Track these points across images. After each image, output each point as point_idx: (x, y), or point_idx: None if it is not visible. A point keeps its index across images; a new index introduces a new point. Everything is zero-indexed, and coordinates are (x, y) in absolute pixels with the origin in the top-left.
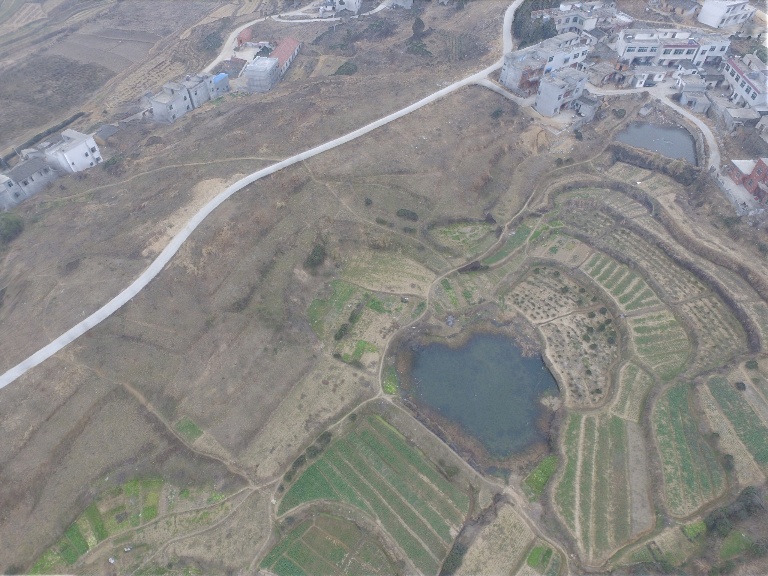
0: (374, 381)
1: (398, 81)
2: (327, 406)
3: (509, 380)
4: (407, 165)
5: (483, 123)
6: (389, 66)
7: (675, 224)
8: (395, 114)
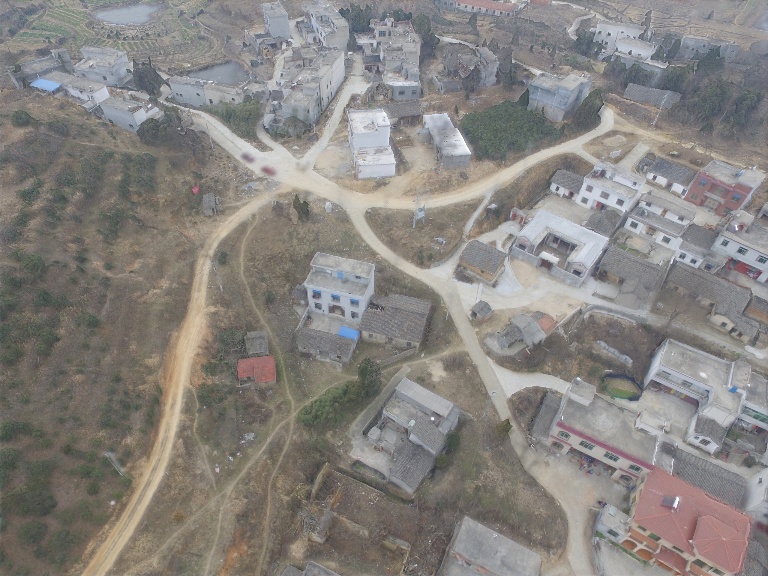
0: None
1: None
2: None
3: (125, 21)
4: None
5: None
6: None
7: (142, 60)
8: None
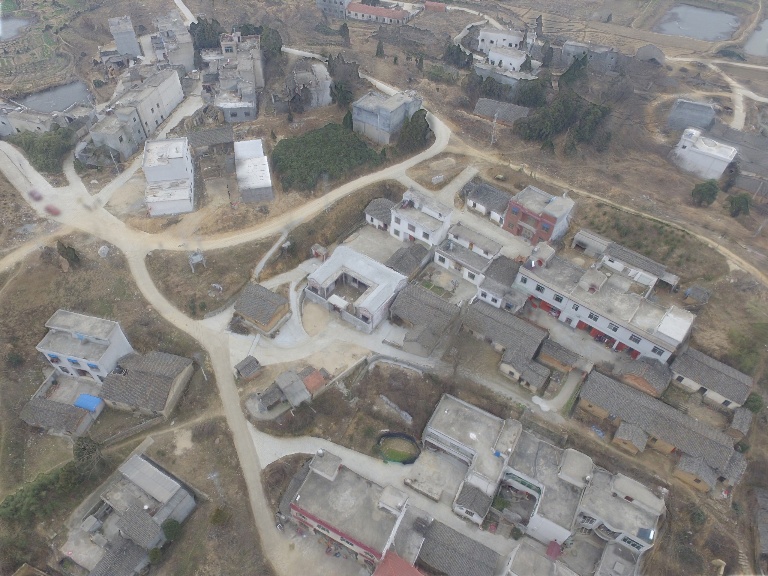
0: (25, 8)
1: (230, 8)
2: (28, 0)
3: None
4: (124, 1)
5: (139, 24)
6: (306, 36)
7: None
8: (180, 0)
